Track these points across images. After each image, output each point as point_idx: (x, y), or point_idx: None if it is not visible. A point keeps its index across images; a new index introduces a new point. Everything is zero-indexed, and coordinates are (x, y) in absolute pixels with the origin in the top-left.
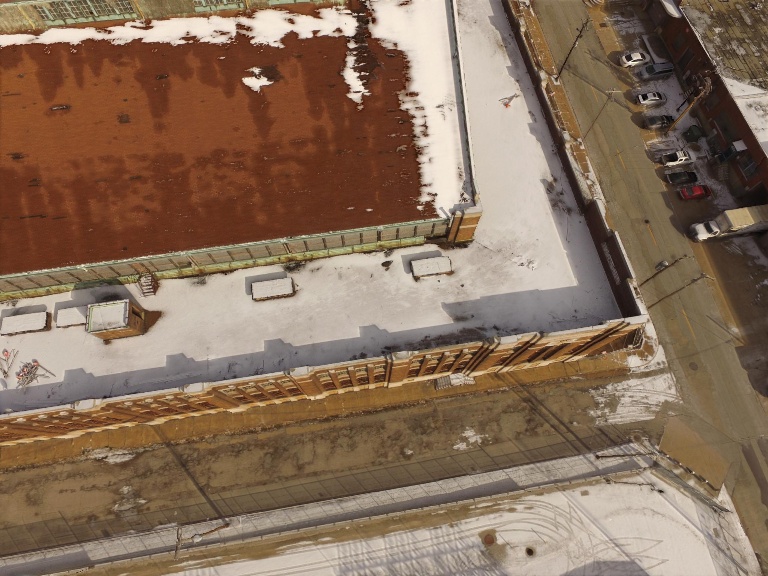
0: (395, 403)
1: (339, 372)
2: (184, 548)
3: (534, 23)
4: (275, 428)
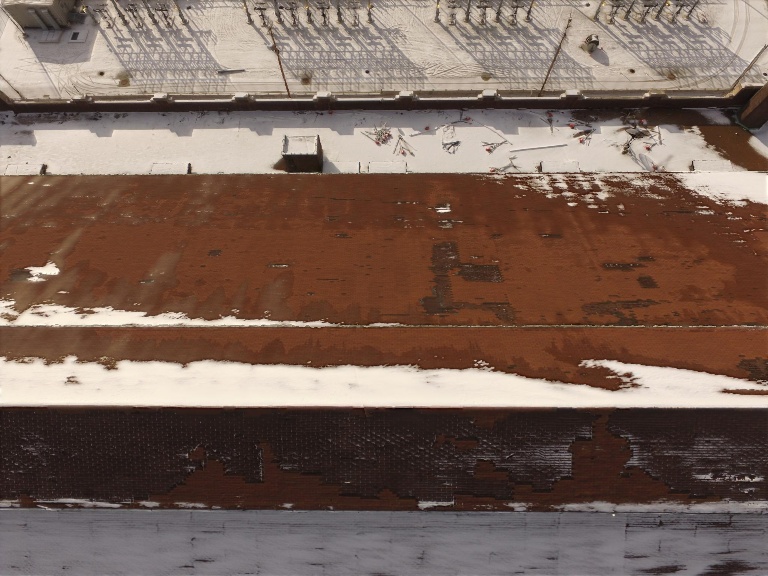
0: None
1: None
2: None
3: None
4: None
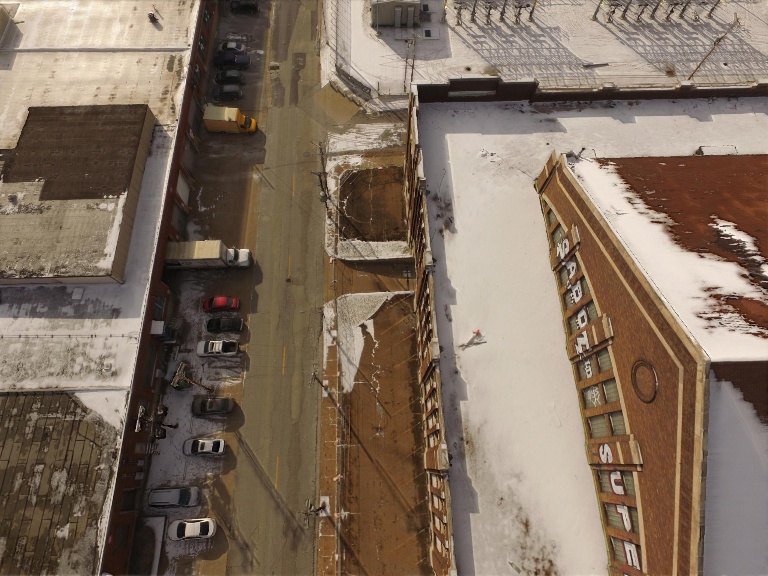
0: None
1: None
2: None
3: None
4: None
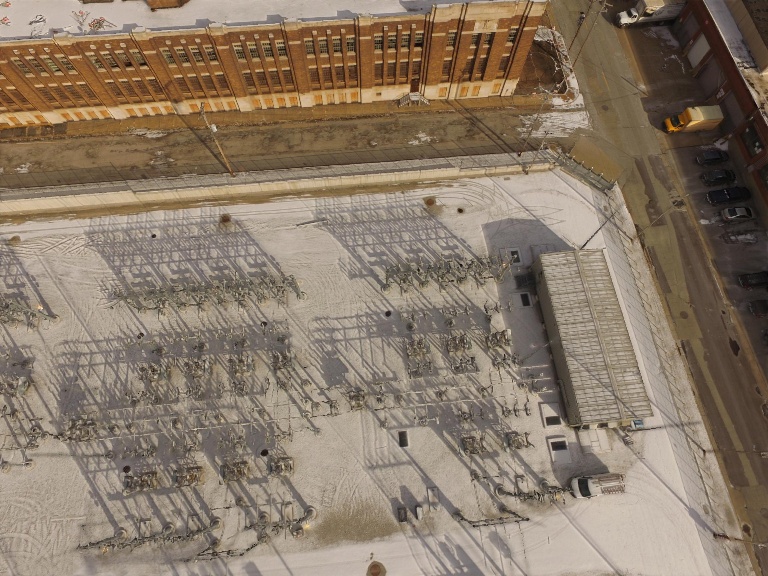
0: (366, 114)
1: (321, 45)
2: (202, 187)
3: None
4: (273, 124)
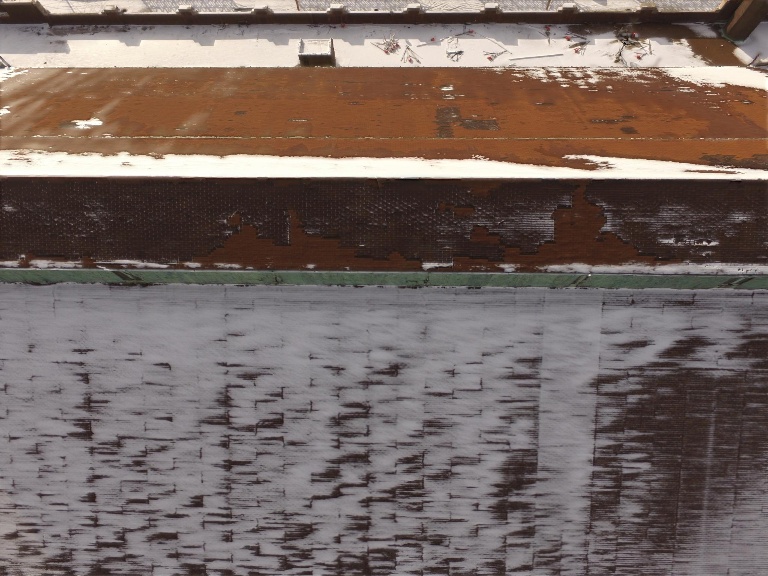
0: None
1: None
2: None
3: None
4: None
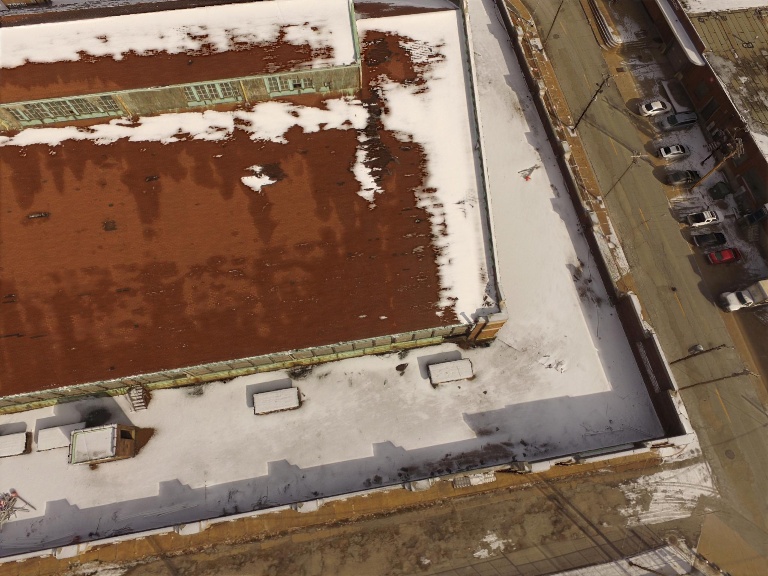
0: (410, 504)
1: None
2: None
3: (547, 68)
4: (280, 535)
